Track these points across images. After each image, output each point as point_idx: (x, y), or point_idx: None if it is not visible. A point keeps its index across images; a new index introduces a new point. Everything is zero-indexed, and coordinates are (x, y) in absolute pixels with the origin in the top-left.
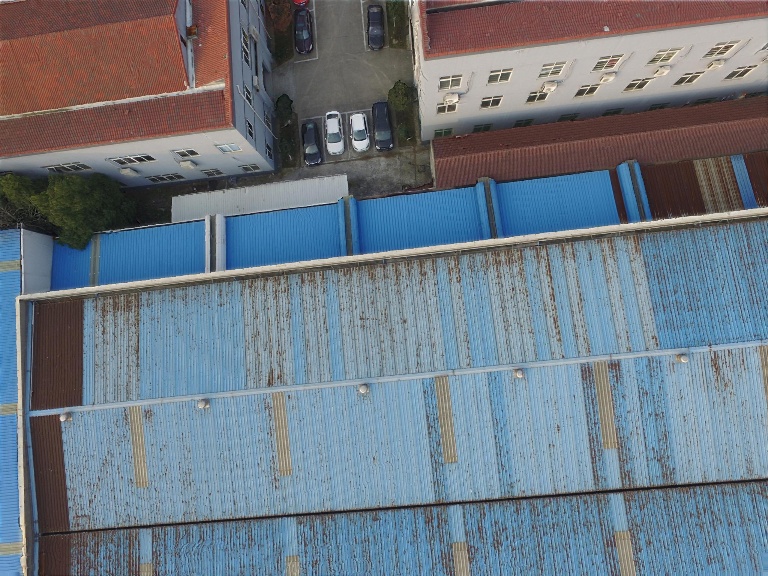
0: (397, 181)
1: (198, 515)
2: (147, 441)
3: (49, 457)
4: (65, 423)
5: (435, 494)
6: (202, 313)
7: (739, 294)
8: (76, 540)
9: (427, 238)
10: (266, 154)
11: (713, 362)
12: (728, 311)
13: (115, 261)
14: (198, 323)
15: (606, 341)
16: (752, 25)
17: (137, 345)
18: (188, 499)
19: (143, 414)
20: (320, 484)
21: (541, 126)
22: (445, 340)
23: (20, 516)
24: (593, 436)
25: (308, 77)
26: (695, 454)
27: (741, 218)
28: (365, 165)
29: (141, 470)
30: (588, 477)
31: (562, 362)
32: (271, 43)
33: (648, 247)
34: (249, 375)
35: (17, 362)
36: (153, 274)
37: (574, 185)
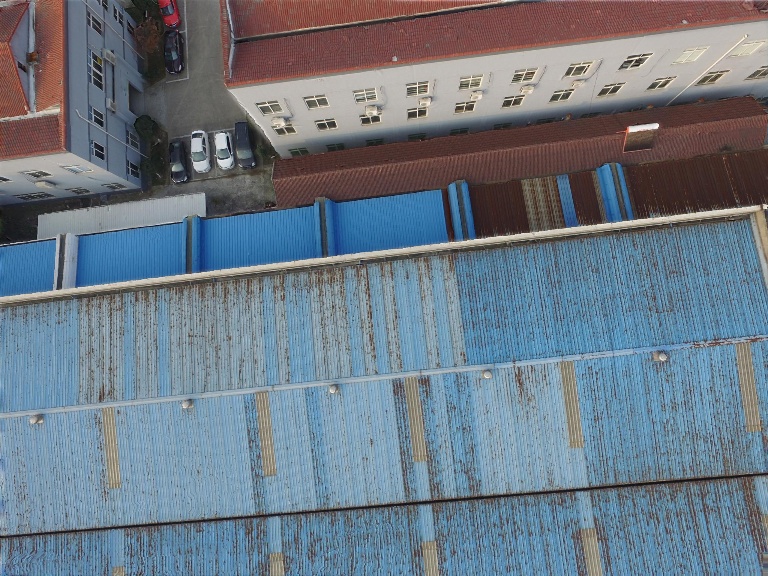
0: (261, 198)
1: (32, 527)
2: None
3: None
4: None
5: (255, 506)
6: (41, 331)
7: (544, 311)
8: None
9: (266, 256)
10: (127, 173)
11: (517, 377)
12: (533, 328)
13: None
14: (36, 340)
15: (417, 357)
16: (535, 55)
17: None
18: (23, 512)
19: None
20: (147, 497)
21: (378, 147)
22: (267, 357)
23: None
24: (404, 449)
25: (179, 97)
26: (500, 466)
27: (549, 238)
28: (231, 183)
29: None
30: (399, 489)
31: (375, 378)
32: (144, 63)
33: (462, 266)
34: (81, 391)
35: None
36: (6, 292)
37: (408, 204)
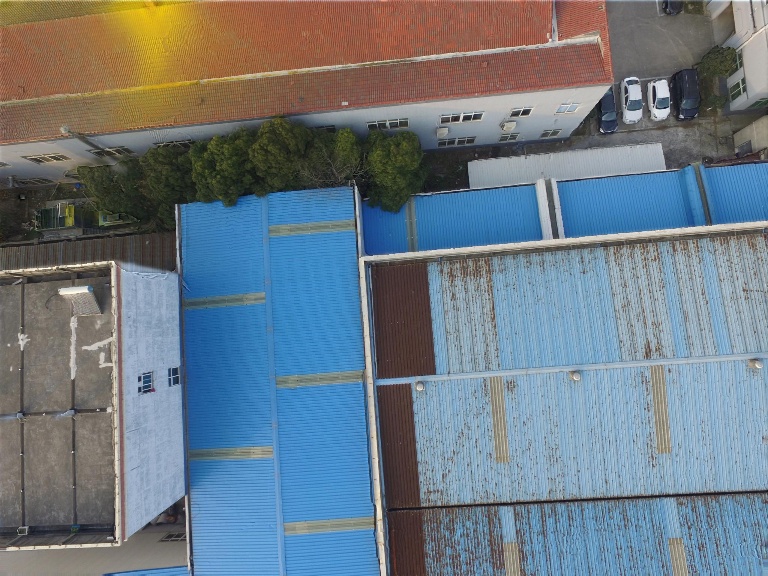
0: (697, 153)
1: (565, 493)
2: (509, 414)
3: (398, 428)
4: (416, 393)
5: None
6: (563, 280)
7: None
8: (428, 516)
9: None
10: None
11: None
12: None
13: (434, 225)
14: (560, 291)
15: None
16: None
17: (493, 312)
18: (554, 476)
19: (505, 385)
20: (702, 463)
21: None
22: None
23: (375, 490)
24: None
25: None
26: None
27: None
28: (661, 135)
29: (502, 444)
30: None
31: None
32: None
33: None
34: (623, 347)
35: (364, 327)
36: (479, 240)
37: None
